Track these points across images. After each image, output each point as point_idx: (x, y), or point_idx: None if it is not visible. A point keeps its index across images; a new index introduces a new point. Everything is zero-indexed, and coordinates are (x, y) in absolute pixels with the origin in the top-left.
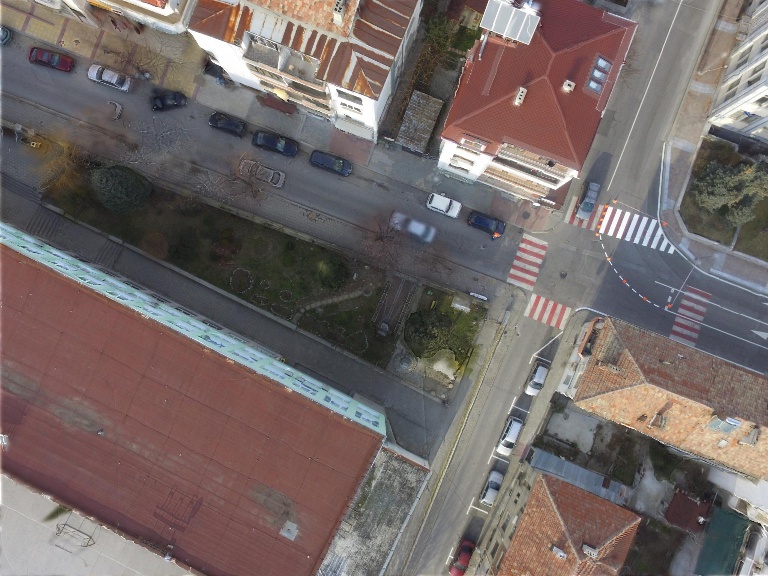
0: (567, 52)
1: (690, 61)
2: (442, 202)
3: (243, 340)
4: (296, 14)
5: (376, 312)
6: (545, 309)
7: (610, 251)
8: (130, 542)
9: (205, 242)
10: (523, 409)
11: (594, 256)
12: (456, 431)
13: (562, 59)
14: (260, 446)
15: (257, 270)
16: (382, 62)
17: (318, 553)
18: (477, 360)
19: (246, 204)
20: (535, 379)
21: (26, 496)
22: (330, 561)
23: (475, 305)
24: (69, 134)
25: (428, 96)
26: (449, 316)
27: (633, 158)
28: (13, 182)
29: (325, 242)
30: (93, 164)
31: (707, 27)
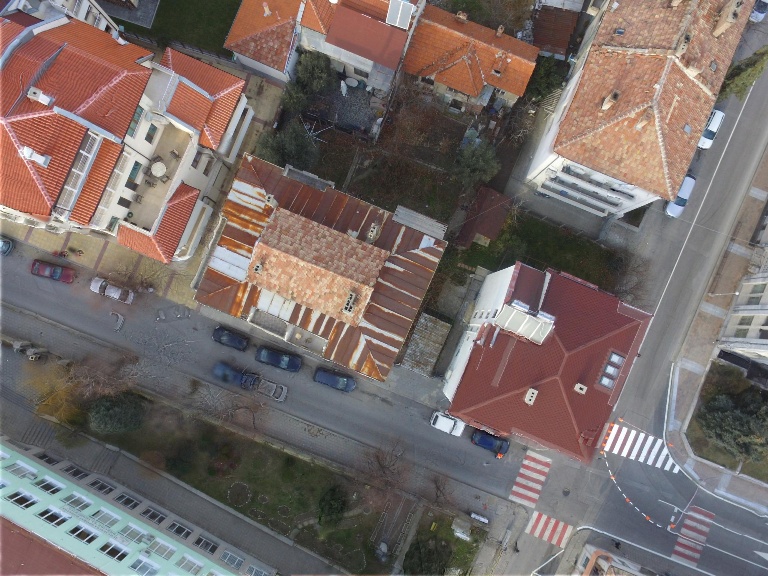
0: (580, 351)
1: (701, 282)
2: (446, 424)
3: (239, 557)
4: (305, 301)
5: (375, 531)
6: (546, 526)
7: (614, 469)
8: None
9: (204, 455)
10: None
11: (598, 474)
12: None
13: (574, 358)
14: None
15: (256, 484)
16: (391, 344)
17: None
18: None
19: (247, 418)
20: None
21: None
22: None
23: (476, 527)
24: (69, 346)
25: (436, 319)
26: (449, 541)
27: (640, 378)
28: (10, 392)
29: (326, 460)
30: (92, 380)
31: (719, 249)
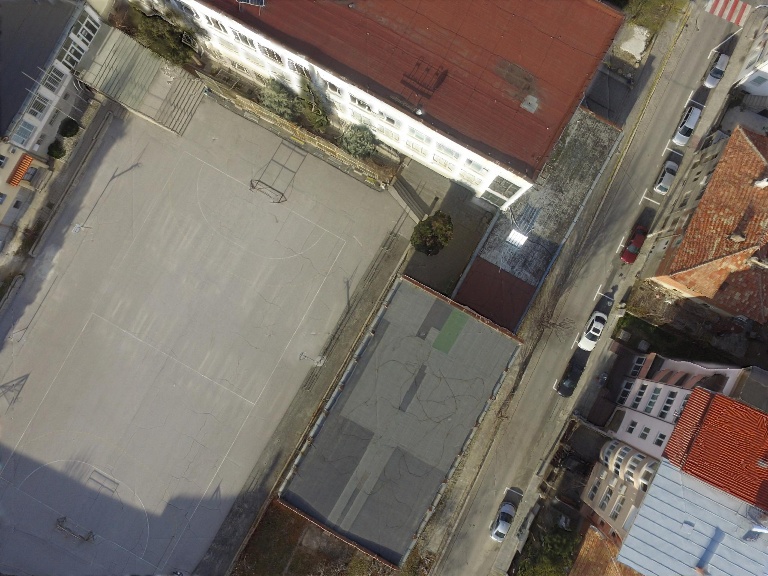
0: None
1: None
2: None
3: None
4: None
5: None
6: (726, 5)
7: None
8: (320, 201)
9: None
10: (699, 103)
11: None
12: (637, 114)
13: None
14: (504, 23)
15: None
16: None
17: (557, 125)
18: (660, 48)
19: None
20: (717, 66)
21: (222, 152)
22: (523, 211)
23: None
24: None
25: None
26: None
27: None
28: None
29: None
30: None
31: None
